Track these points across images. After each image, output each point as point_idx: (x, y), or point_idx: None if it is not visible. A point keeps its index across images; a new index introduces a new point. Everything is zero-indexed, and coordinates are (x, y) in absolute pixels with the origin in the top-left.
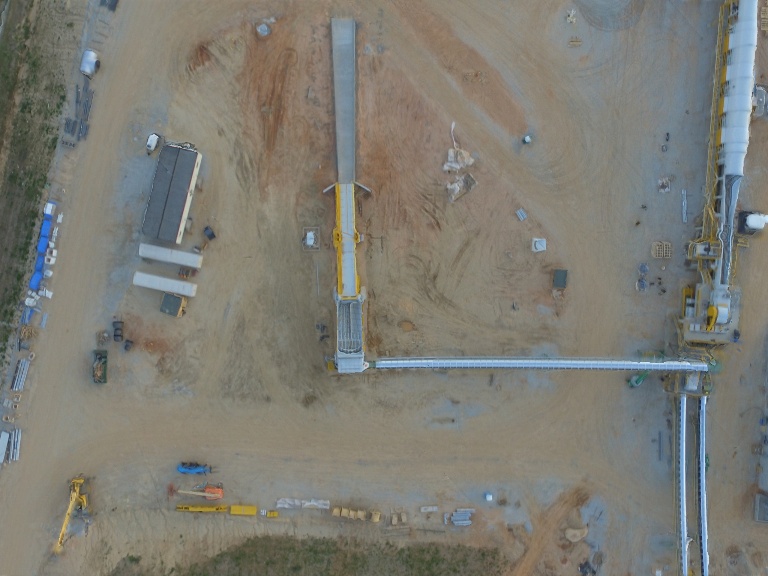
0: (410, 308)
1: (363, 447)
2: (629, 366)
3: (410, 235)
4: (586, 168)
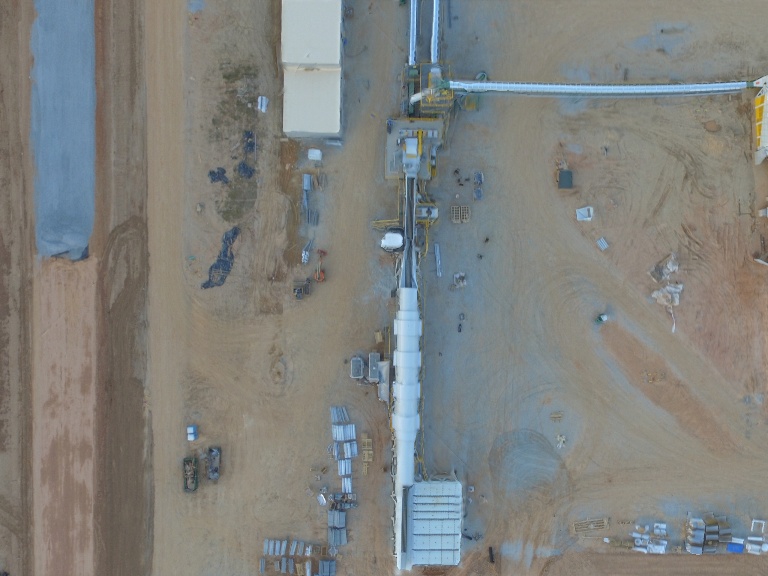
0: (712, 144)
1: (753, 0)
2: (518, 87)
3: (713, 218)
4: (540, 293)
